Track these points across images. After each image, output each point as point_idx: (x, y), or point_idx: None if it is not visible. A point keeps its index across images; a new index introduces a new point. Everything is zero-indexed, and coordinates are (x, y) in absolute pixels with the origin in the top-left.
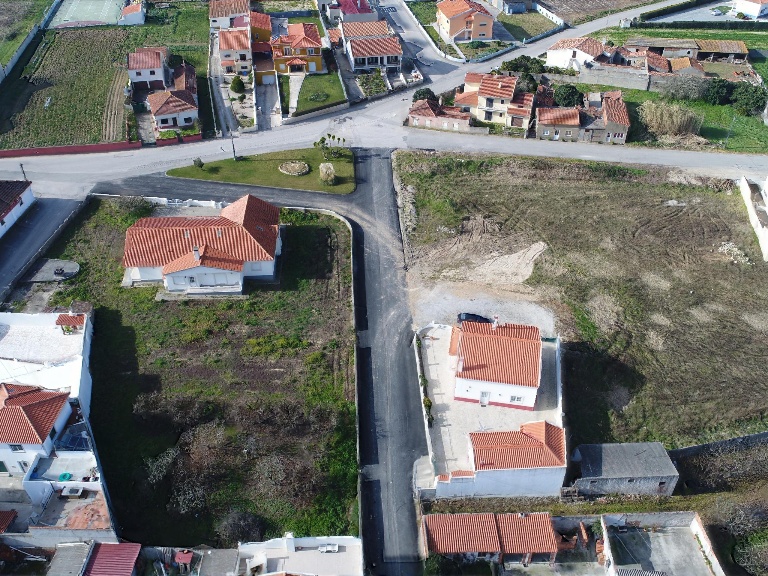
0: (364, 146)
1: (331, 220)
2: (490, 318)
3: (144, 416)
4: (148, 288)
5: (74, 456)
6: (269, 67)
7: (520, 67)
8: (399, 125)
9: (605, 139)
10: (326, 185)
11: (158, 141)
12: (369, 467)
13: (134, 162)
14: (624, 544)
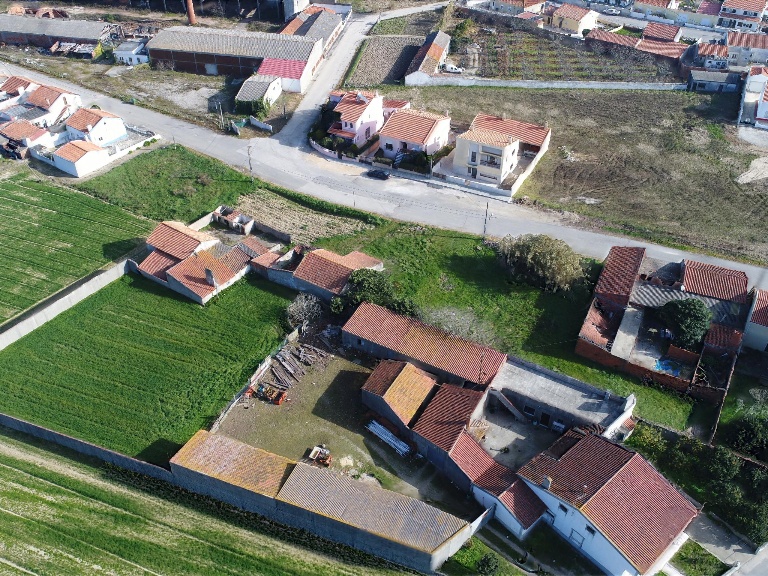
0: None
1: None
2: None
3: None
4: None
5: None
6: None
7: (764, 484)
8: None
9: None
10: None
11: None
12: None
13: None
14: None
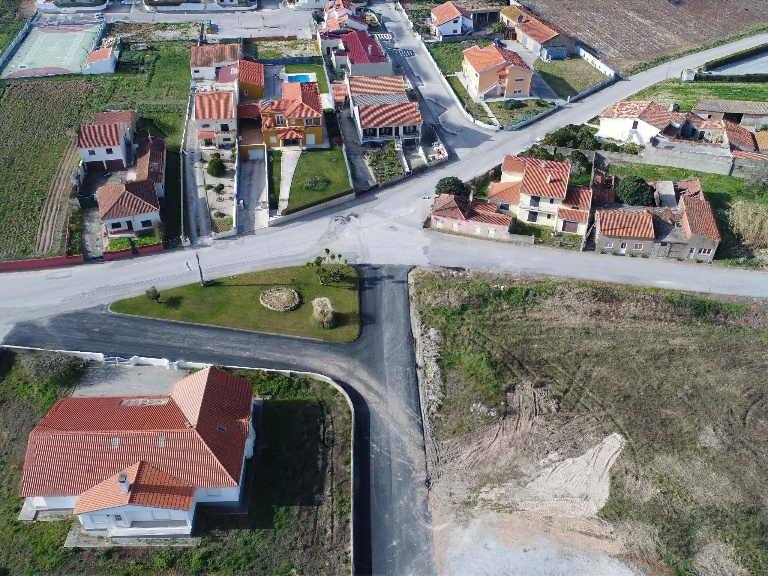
0: (373, 262)
1: (325, 390)
2: None
3: None
4: (57, 523)
5: None
6: (258, 138)
7: (568, 140)
8: (418, 227)
9: (686, 255)
10: (321, 328)
11: (105, 254)
12: None
13: (70, 288)
14: None
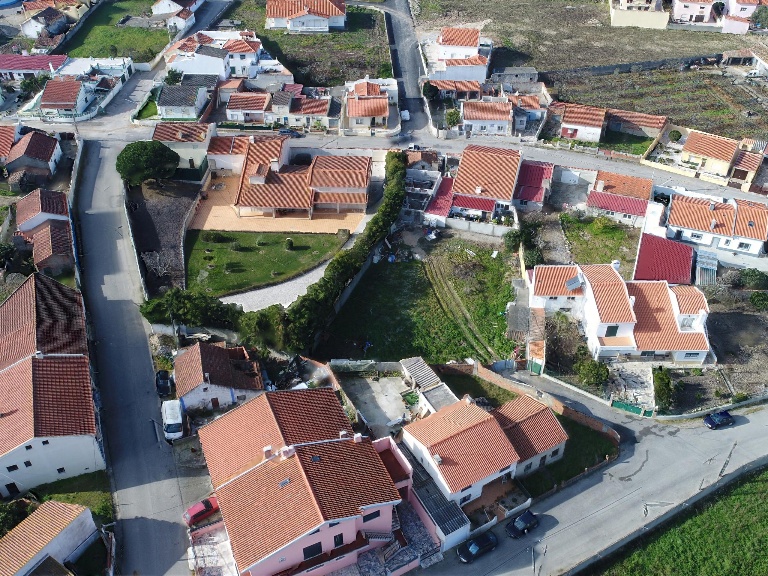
0: None
1: (372, 11)
2: None
3: (293, 59)
4: (279, 30)
5: (268, 62)
6: None
7: None
8: None
9: None
10: None
11: None
12: (398, 78)
13: None
14: None
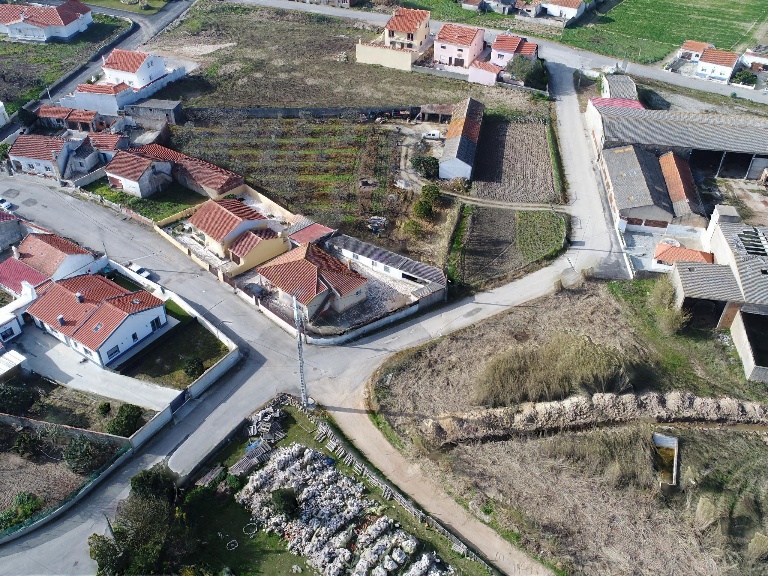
0: None
1: (126, 23)
2: (164, 64)
3: None
4: (1, 36)
5: None
6: None
7: None
8: None
9: (337, 4)
10: (140, 9)
11: None
12: (44, 100)
13: None
14: (132, 132)
